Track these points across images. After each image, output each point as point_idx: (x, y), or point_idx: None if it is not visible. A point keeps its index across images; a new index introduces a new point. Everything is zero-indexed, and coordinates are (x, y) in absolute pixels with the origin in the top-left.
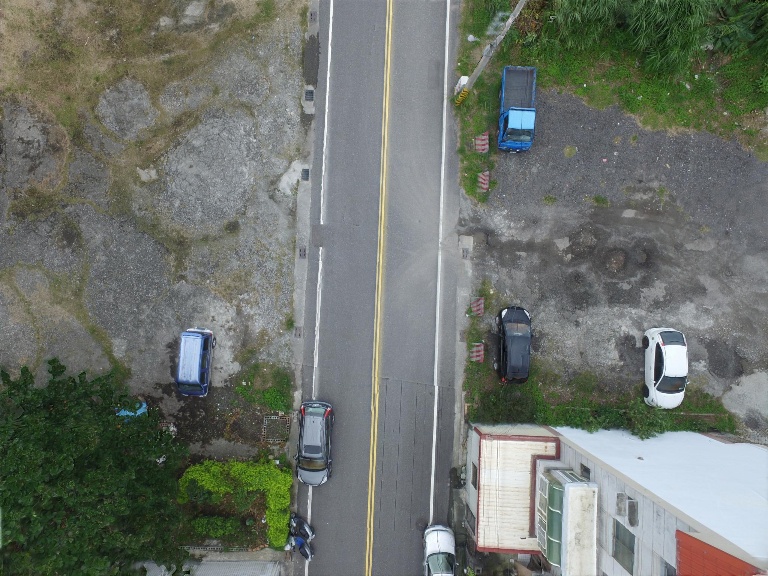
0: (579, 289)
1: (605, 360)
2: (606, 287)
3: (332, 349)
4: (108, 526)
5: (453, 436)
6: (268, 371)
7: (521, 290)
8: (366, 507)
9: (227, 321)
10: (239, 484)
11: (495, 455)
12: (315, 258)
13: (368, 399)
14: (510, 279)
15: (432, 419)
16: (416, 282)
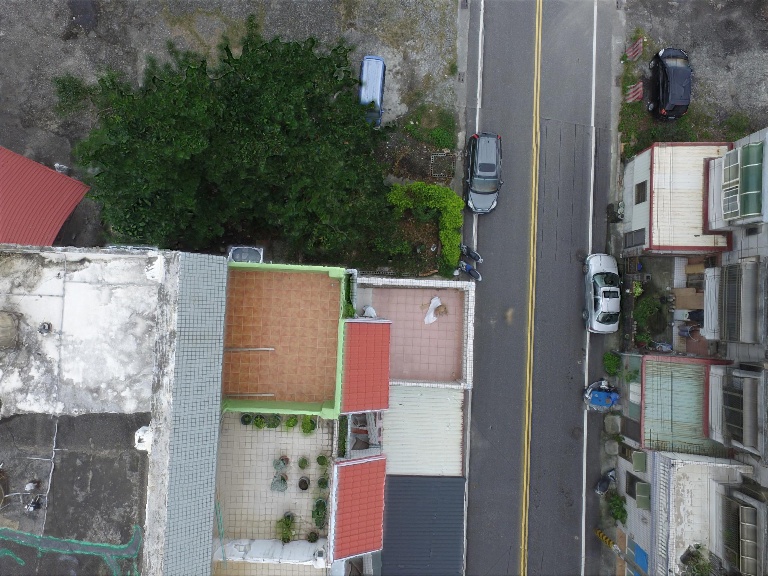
0: (729, 37)
1: (755, 102)
2: (755, 35)
3: (494, 92)
4: (350, 151)
5: (610, 174)
6: (434, 112)
7: (674, 38)
8: (529, 238)
9: (394, 66)
10: (418, 200)
11: (668, 160)
12: (477, 8)
13: (529, 138)
14: (663, 27)
15: (590, 158)
16: (574, 30)
